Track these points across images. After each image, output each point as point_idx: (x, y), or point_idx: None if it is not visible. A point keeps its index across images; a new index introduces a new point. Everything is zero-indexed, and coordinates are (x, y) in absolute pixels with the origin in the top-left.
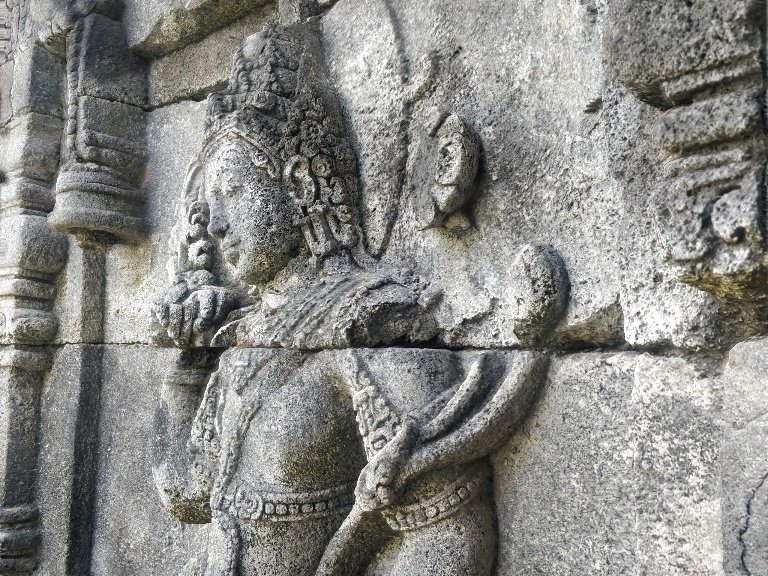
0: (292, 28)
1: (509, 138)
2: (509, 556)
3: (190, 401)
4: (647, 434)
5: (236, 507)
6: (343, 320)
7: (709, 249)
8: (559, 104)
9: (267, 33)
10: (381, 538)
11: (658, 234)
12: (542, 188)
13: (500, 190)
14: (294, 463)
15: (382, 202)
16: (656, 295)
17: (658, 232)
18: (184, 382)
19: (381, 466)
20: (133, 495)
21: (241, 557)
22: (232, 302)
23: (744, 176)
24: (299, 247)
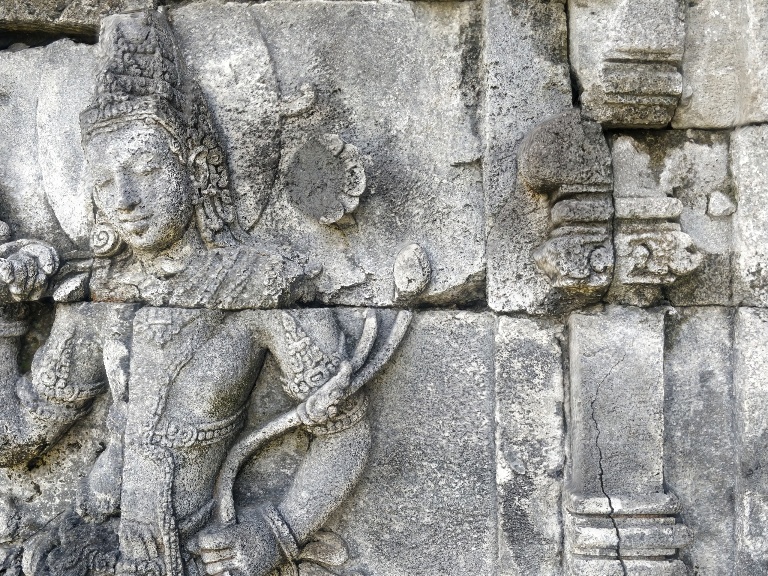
0: (160, 18)
1: (386, 167)
2: (378, 439)
3: (12, 352)
4: (507, 359)
5: (170, 440)
6: (274, 289)
7: (590, 274)
8: (428, 154)
9: (148, 21)
10: (265, 444)
11: (561, 263)
12: (413, 206)
13: (377, 201)
14: (222, 398)
15: (254, 190)
16: (518, 286)
17: (562, 262)
18: (11, 335)
19: (336, 393)
20: None
21: (174, 478)
22: None
23: (605, 242)
24: (190, 221)
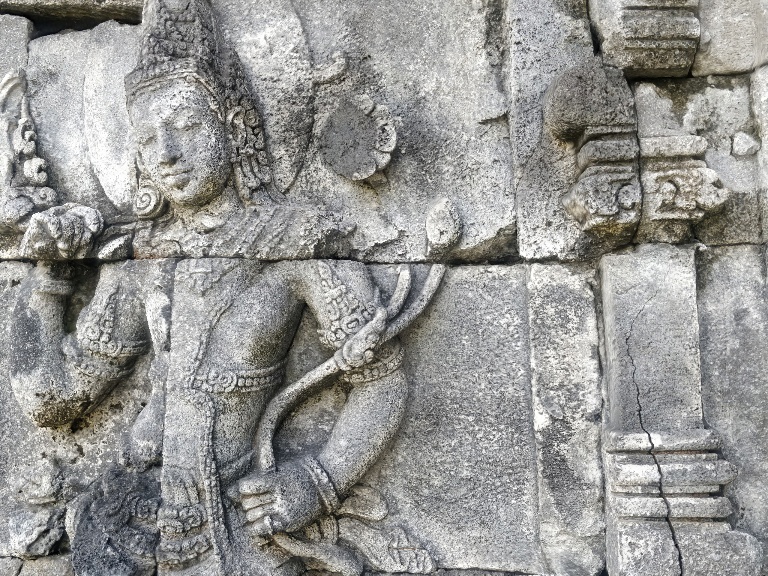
0: None
1: (416, 128)
2: (414, 393)
3: (58, 310)
4: (540, 306)
5: (211, 384)
6: (310, 239)
7: (618, 211)
8: (456, 114)
9: None
10: (303, 399)
11: (589, 202)
12: (443, 164)
13: (407, 160)
14: (260, 346)
15: (289, 153)
16: (548, 233)
17: (590, 201)
18: (58, 292)
19: (372, 336)
20: None
21: (215, 423)
22: None
23: (632, 180)
24: (229, 180)
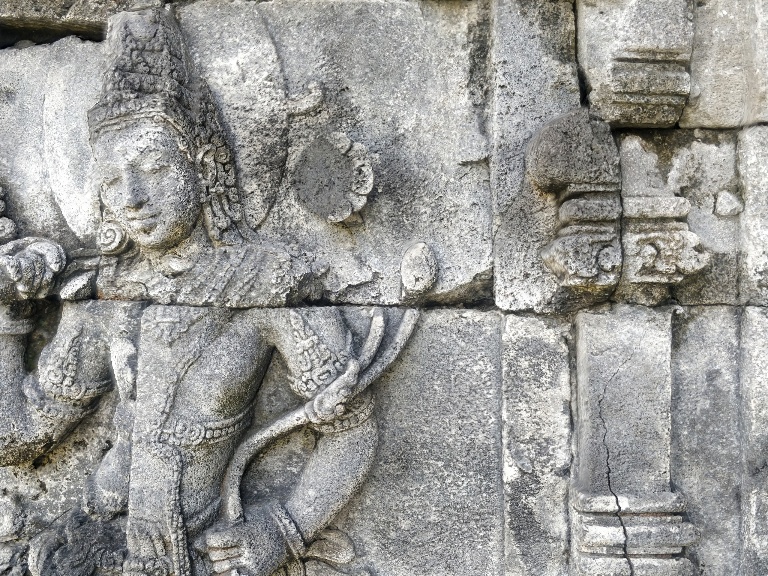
0: (168, 16)
1: (394, 166)
2: (384, 437)
3: (19, 350)
4: (514, 358)
5: (178, 438)
6: (282, 287)
7: None
8: (435, 153)
9: (156, 19)
10: (272, 442)
11: (569, 262)
12: (421, 205)
13: (384, 200)
14: (229, 397)
15: (261, 188)
16: (525, 285)
17: (570, 261)
18: (18, 333)
19: (344, 391)
20: None
21: (182, 476)
22: (66, 255)
23: (613, 241)
24: (198, 219)
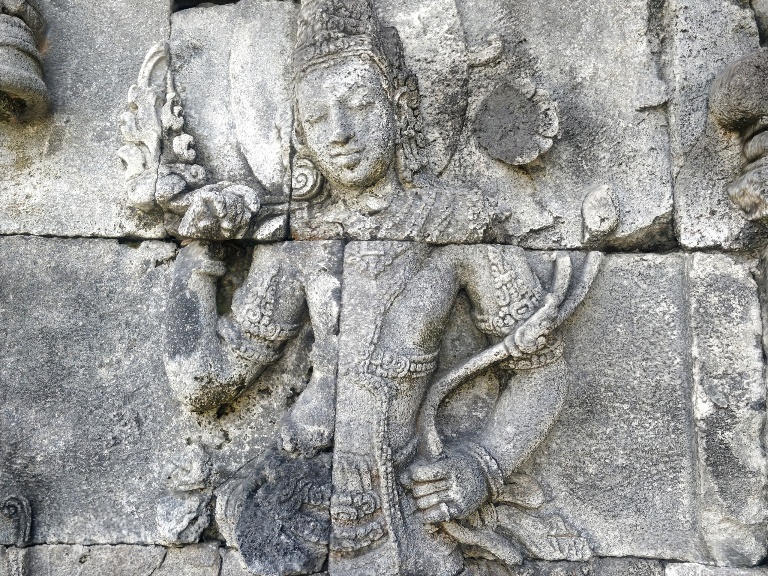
0: None
1: (572, 113)
2: None
3: None
4: (703, 294)
5: (385, 369)
6: (479, 223)
7: None
8: (612, 101)
9: None
10: None
11: (766, 191)
12: (599, 151)
13: (563, 146)
14: (430, 331)
15: (443, 136)
16: (712, 222)
17: (767, 190)
18: (216, 273)
19: (546, 323)
20: (36, 403)
21: None
22: None
23: None
24: (391, 161)
